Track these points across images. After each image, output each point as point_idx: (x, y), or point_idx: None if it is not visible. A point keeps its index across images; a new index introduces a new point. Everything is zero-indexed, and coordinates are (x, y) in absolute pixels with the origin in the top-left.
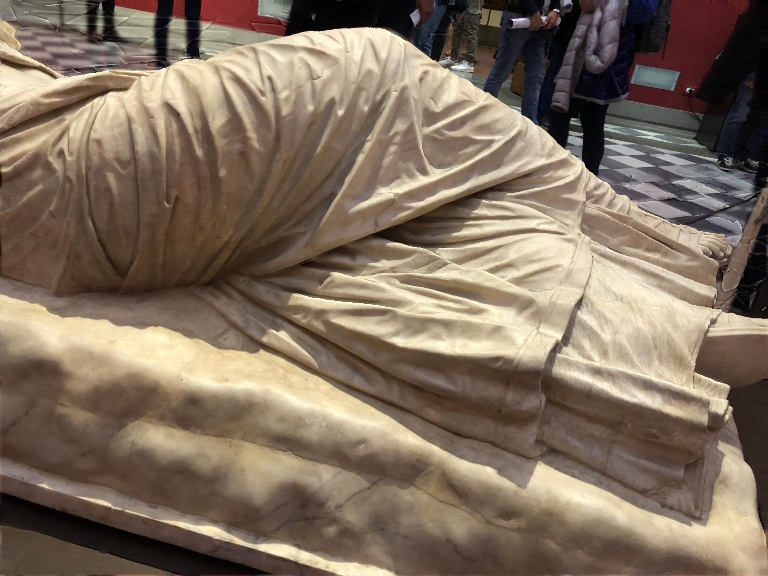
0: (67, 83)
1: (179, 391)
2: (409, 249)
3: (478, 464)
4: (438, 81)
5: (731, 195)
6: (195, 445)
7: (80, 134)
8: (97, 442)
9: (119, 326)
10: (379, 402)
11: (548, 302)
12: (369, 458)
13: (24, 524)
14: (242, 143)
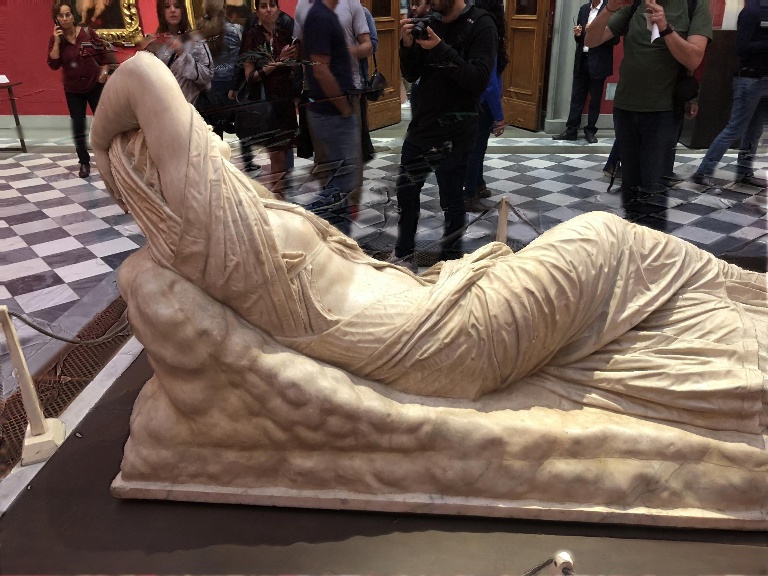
0: (459, 285)
1: (568, 439)
2: (653, 334)
3: (736, 443)
4: (641, 236)
5: (719, 187)
6: (583, 465)
7: (482, 313)
8: (529, 476)
9: (517, 411)
10: (666, 422)
11: (744, 350)
12: (677, 452)
13: (490, 530)
14: (566, 300)
